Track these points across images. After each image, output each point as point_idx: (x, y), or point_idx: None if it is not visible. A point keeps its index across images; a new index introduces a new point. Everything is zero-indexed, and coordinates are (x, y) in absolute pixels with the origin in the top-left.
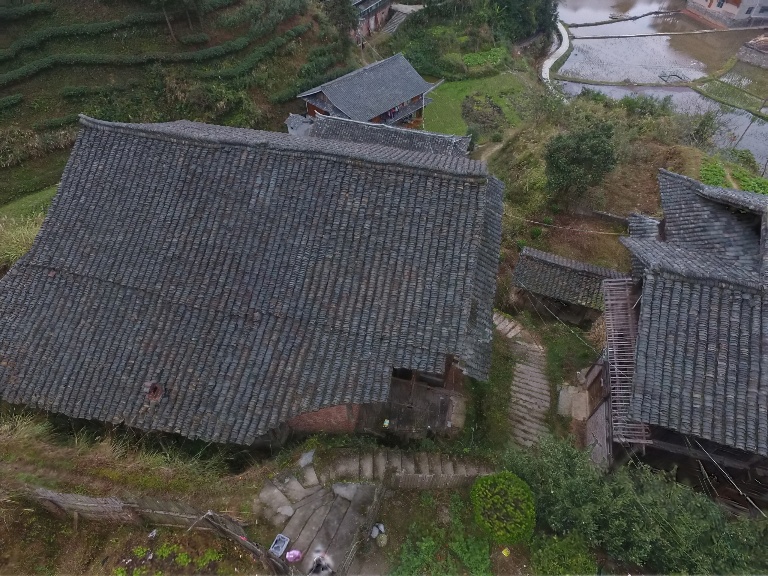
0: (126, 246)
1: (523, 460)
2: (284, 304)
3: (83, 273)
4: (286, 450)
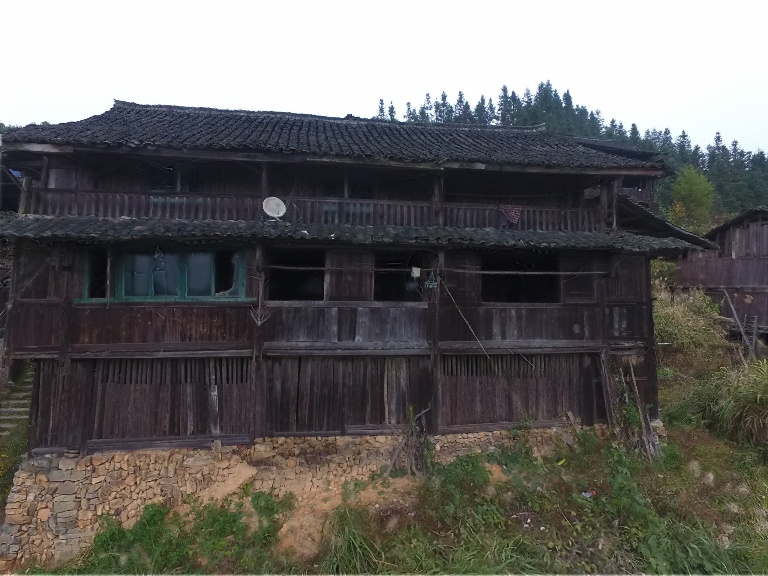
0: None
1: None
2: None
3: None
4: None
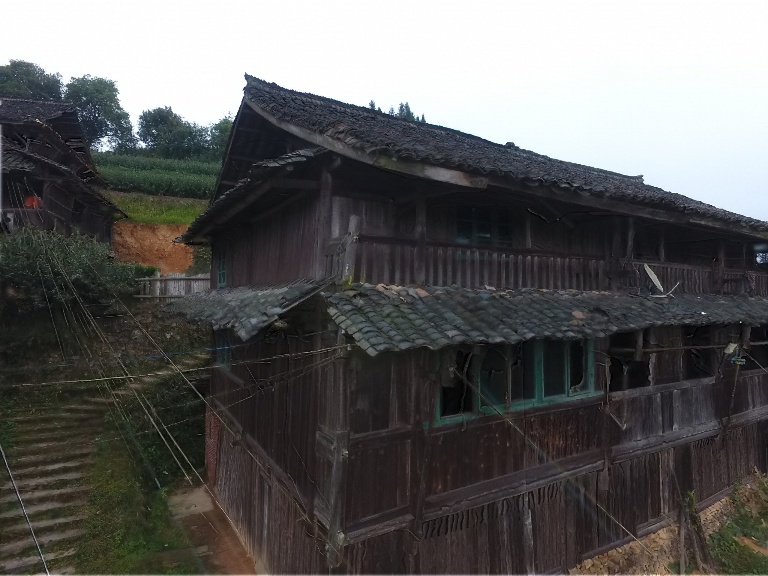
0: None
1: (121, 264)
2: None
3: None
4: None
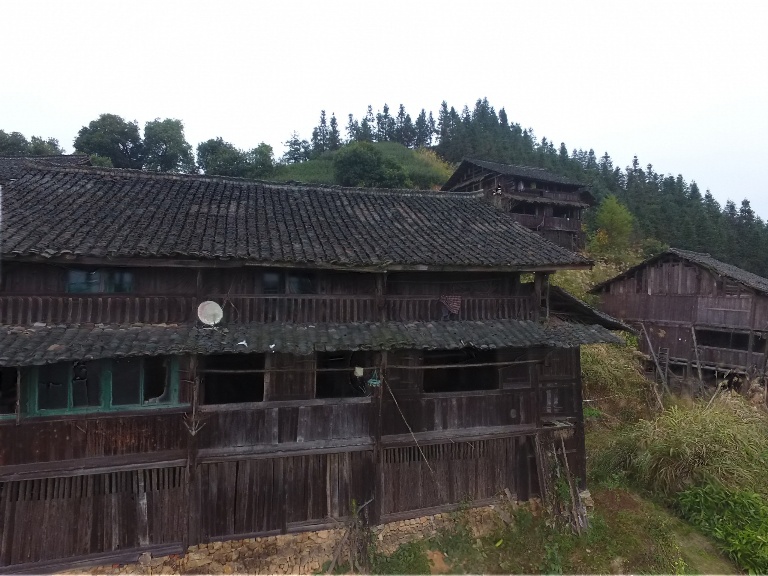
0: None
1: None
2: None
3: None
4: None
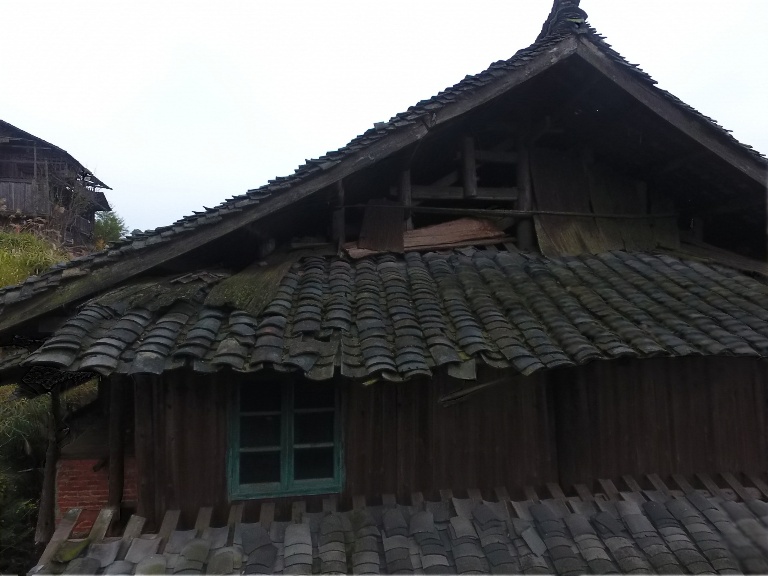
0: None
1: None
2: None
3: None
4: (1, 471)
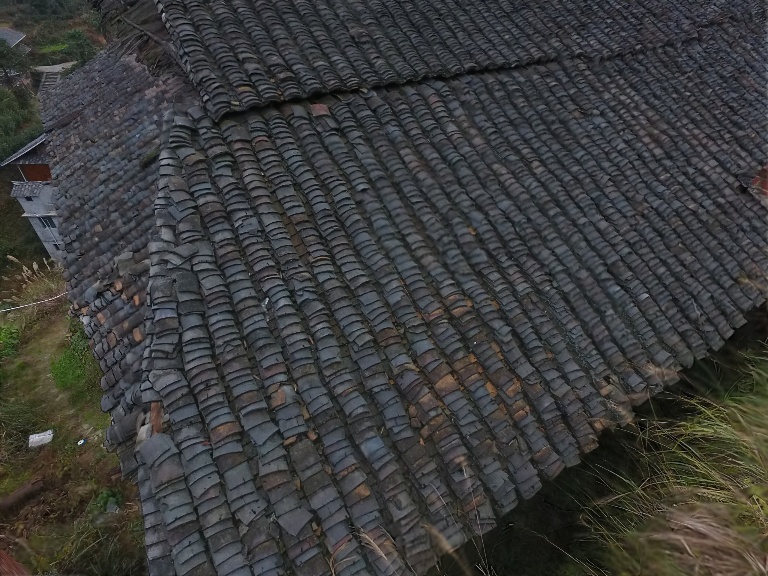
0: (428, 3)
1: None
2: (711, 5)
3: (406, 71)
4: None
